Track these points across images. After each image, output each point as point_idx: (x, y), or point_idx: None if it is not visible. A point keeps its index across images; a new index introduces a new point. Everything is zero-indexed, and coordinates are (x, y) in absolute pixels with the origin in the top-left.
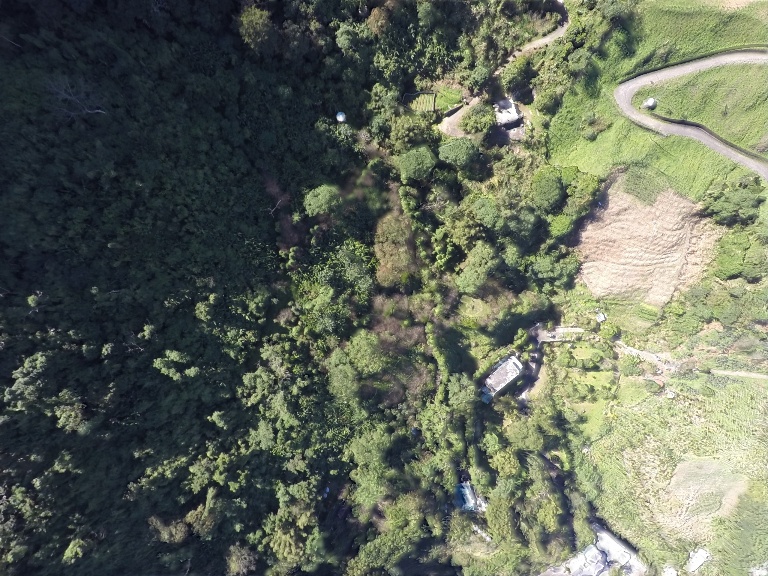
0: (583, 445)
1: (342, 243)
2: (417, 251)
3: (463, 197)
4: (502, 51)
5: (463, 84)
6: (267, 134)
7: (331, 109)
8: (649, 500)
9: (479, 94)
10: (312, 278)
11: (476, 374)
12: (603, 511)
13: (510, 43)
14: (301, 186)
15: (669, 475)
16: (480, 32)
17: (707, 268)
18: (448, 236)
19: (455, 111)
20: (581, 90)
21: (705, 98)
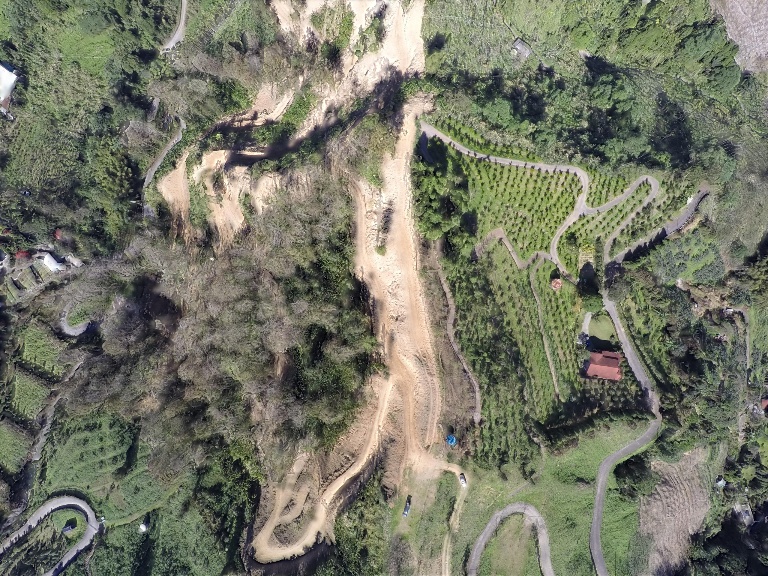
0: None
1: None
2: None
3: None
4: None
5: None
6: None
7: None
8: None
9: None
10: None
11: None
12: None
13: None
14: None
15: None
16: None
17: None
18: None
19: None
20: None
21: (575, 564)
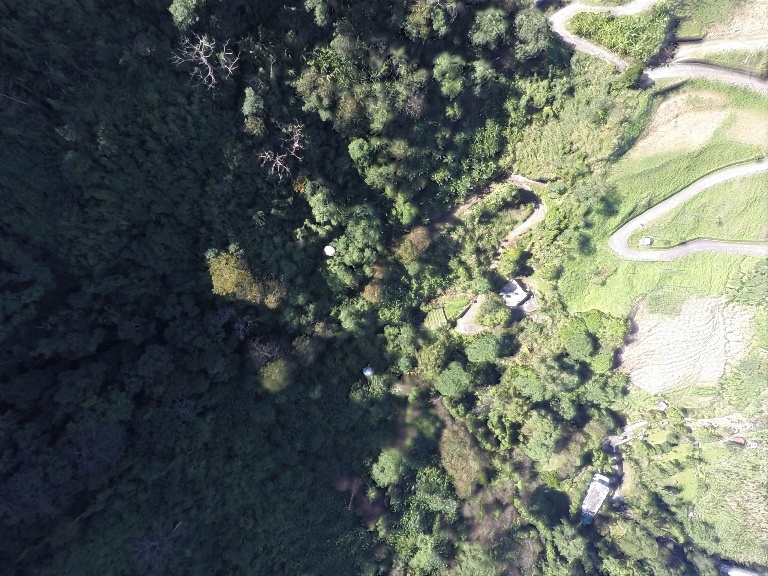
0: (687, 511)
1: (415, 482)
2: (480, 445)
3: (501, 374)
4: (492, 252)
5: (466, 292)
6: (315, 438)
7: (356, 369)
8: (765, 527)
9: (484, 293)
10: (404, 533)
11: (572, 510)
12: (726, 553)
13: (495, 240)
14: (361, 460)
15: None
16: (466, 249)
17: (750, 342)
18: (502, 416)
19: (466, 311)
20: (578, 254)
21: (697, 218)
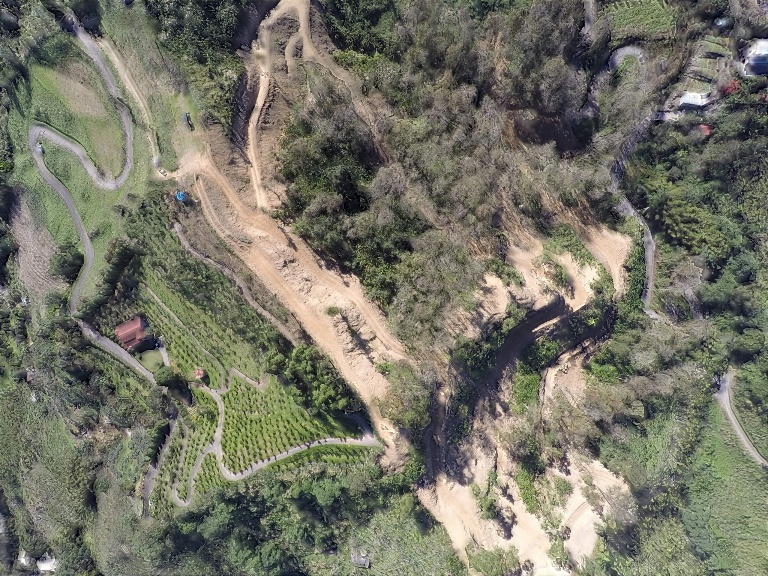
0: None
1: None
2: None
3: None
4: None
5: None
6: None
7: None
8: (20, 476)
9: None
10: None
11: None
12: None
13: None
14: None
15: (29, 465)
16: None
17: None
18: None
19: None
20: None
21: (67, 169)
